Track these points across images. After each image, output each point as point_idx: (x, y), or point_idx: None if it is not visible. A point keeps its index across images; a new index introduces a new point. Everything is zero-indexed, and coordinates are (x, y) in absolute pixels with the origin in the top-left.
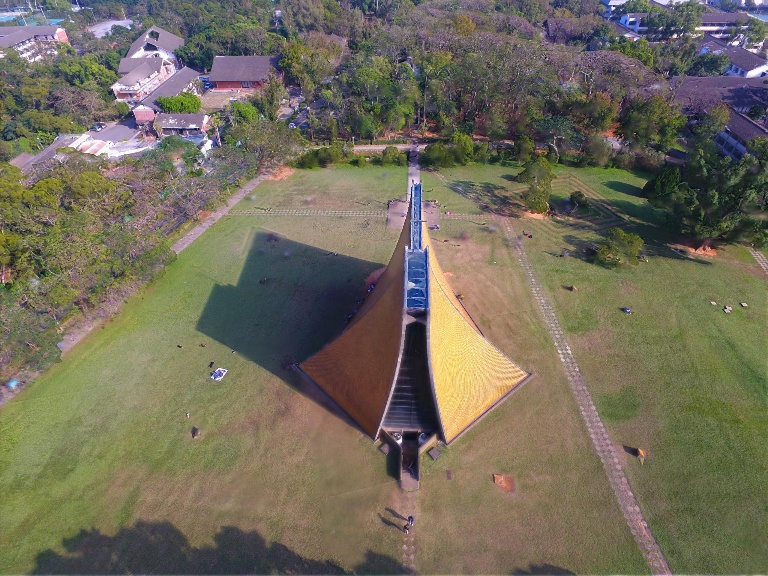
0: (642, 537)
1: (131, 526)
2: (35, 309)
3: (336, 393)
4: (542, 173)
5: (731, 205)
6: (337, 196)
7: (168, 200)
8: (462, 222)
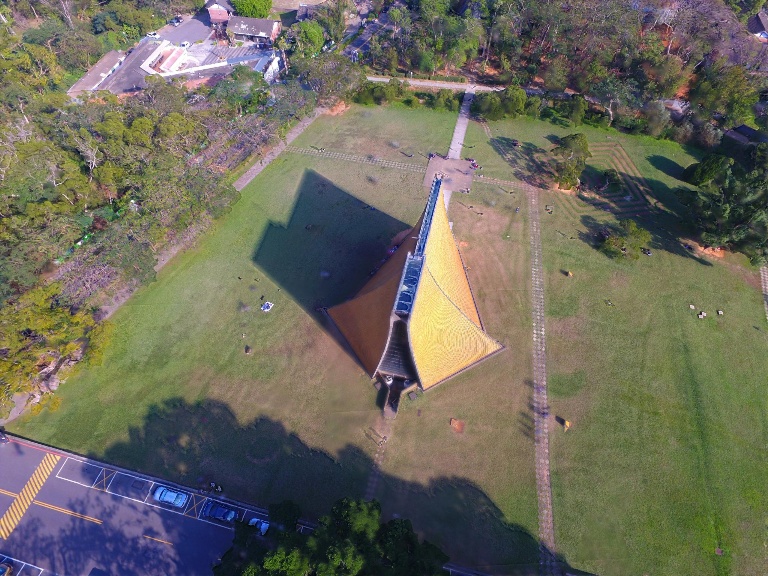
0: (542, 481)
1: (204, 408)
2: (138, 241)
3: (350, 338)
4: (578, 150)
5: (748, 216)
6: (384, 142)
7: (236, 142)
8: (492, 188)
